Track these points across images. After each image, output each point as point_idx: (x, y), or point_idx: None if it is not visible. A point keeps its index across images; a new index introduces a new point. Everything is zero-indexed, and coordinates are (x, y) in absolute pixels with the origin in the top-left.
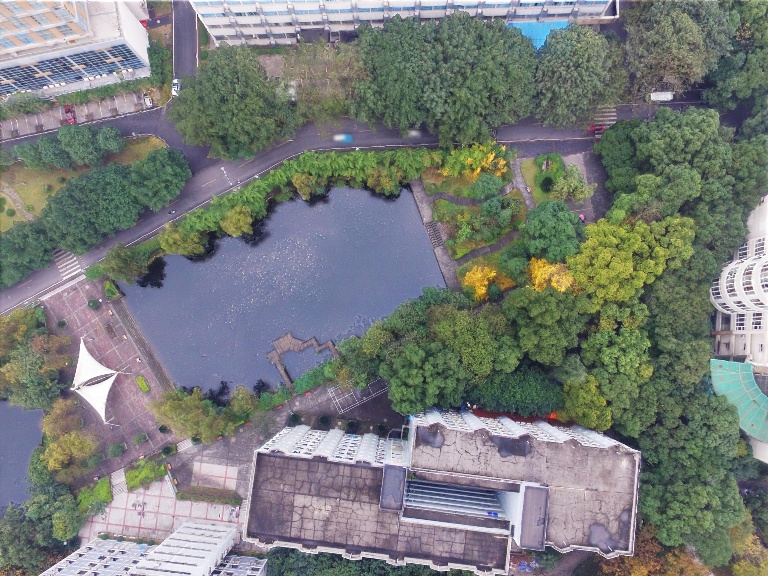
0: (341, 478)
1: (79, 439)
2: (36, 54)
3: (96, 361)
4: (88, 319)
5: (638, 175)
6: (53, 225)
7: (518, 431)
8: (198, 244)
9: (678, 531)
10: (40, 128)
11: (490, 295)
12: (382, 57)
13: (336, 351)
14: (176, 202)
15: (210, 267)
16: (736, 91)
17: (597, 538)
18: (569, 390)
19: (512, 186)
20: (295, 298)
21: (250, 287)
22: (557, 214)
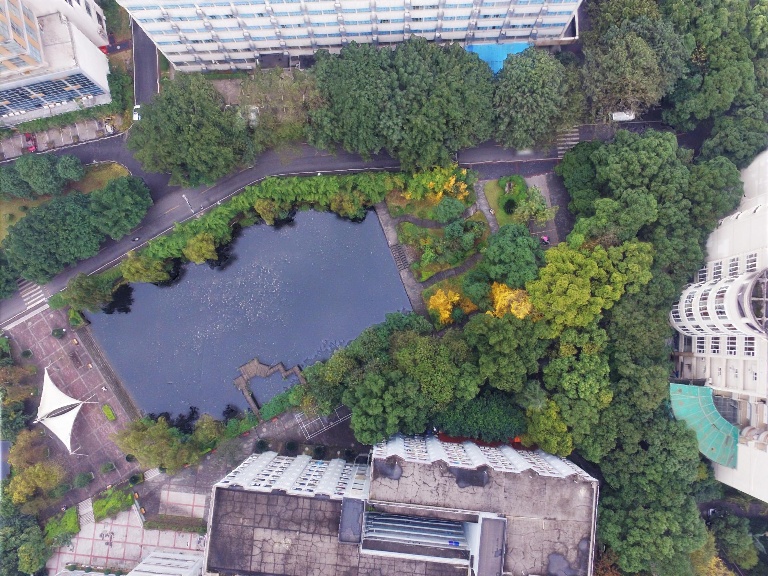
0: (300, 511)
1: (44, 471)
2: None
3: (60, 391)
4: (53, 348)
5: (598, 198)
6: (13, 256)
7: (477, 461)
8: (161, 272)
9: (638, 557)
10: (1, 157)
11: (454, 319)
12: (338, 85)
13: None
14: (139, 229)
15: (175, 294)
16: (694, 112)
17: (556, 567)
18: (531, 415)
19: (476, 208)
20: (261, 323)
21: (216, 313)
22: (516, 239)
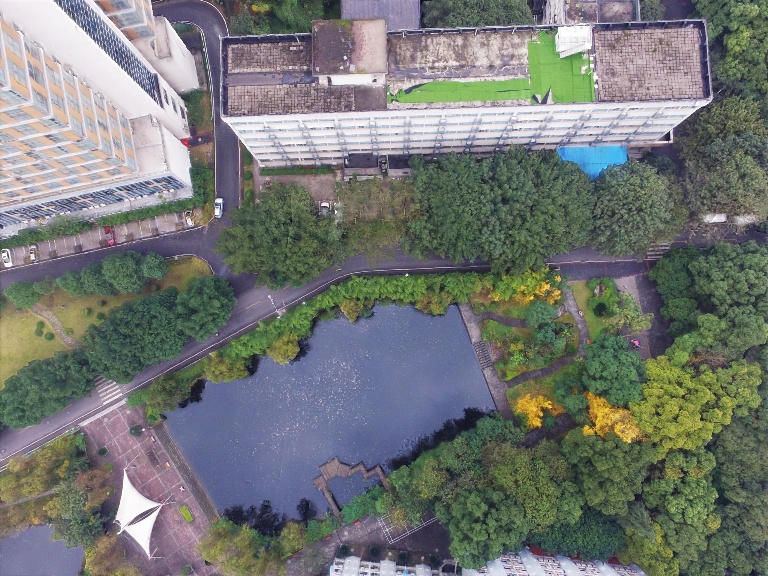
0: None
1: None
2: (81, 189)
3: (140, 494)
4: (129, 445)
5: (698, 310)
6: (96, 358)
7: None
8: (243, 371)
9: None
10: (79, 249)
11: (545, 426)
12: (439, 198)
13: (385, 478)
14: None
15: (254, 389)
16: None
17: None
18: (632, 535)
19: (564, 309)
20: (342, 421)
21: (295, 410)
22: (618, 356)
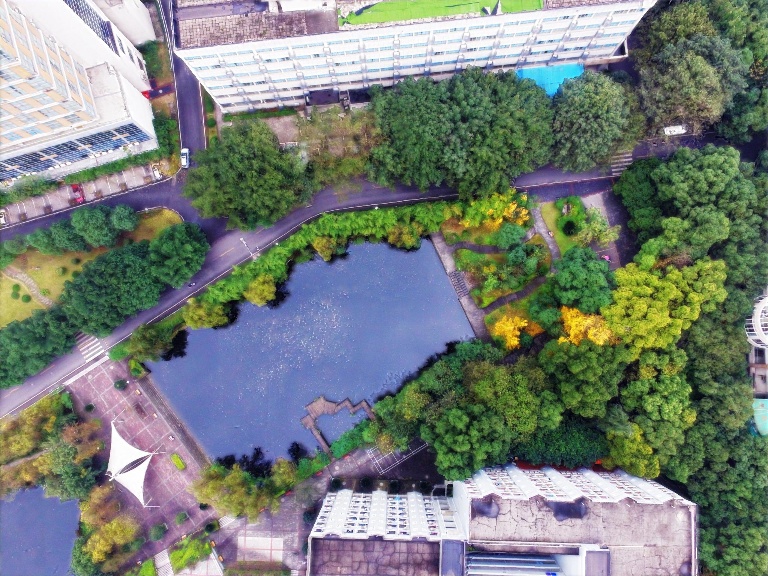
0: (398, 555)
1: (120, 527)
2: (42, 142)
3: (129, 445)
4: (116, 400)
5: (662, 216)
6: (74, 312)
7: (571, 492)
8: (222, 316)
9: (736, 575)
10: (48, 209)
11: (523, 345)
12: (399, 121)
13: (371, 411)
14: (195, 274)
15: (235, 336)
16: (752, 125)
17: None
18: (612, 438)
19: (534, 231)
20: (324, 360)
21: (278, 353)
22: (587, 264)
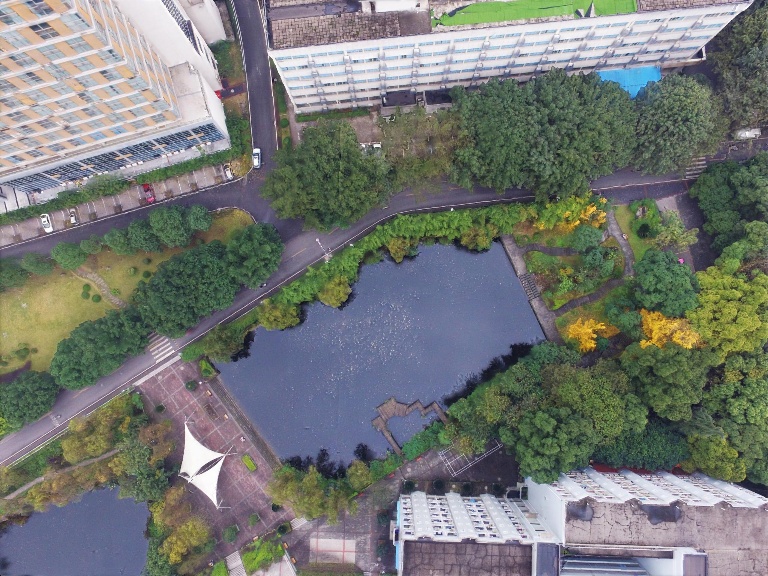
0: (490, 558)
1: (195, 529)
2: (123, 141)
3: (203, 446)
4: (186, 401)
5: (743, 220)
6: (150, 313)
7: (663, 495)
8: (296, 317)
9: None
10: (119, 209)
11: (599, 347)
12: (485, 123)
13: (443, 413)
14: None
15: (305, 337)
16: None
17: None
18: (694, 441)
19: (607, 234)
20: (395, 362)
21: (348, 354)
22: (671, 268)
